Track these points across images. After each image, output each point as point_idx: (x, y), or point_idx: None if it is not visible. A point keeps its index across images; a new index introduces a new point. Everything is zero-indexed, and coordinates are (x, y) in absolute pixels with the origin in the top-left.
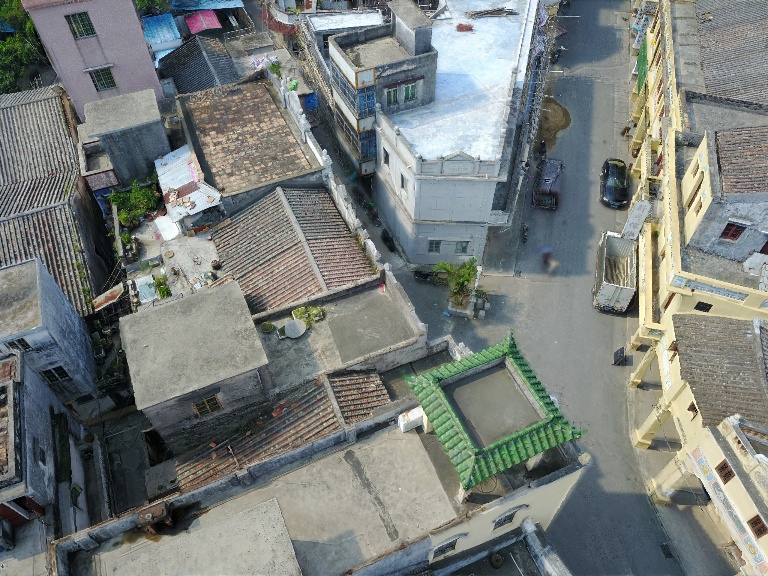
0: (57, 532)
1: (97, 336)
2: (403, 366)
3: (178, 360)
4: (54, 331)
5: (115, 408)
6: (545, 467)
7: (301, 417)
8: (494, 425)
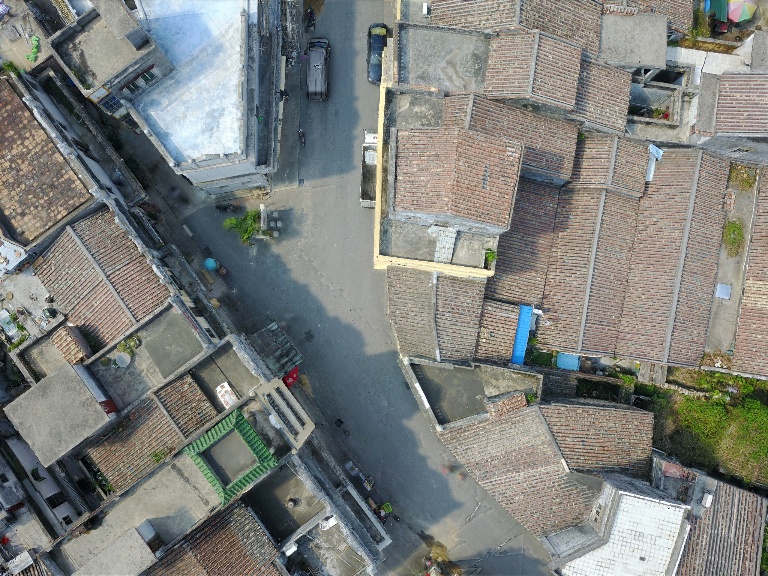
0: (36, 510)
1: None
2: (205, 359)
3: (54, 431)
4: None
5: None
6: (280, 449)
7: (148, 419)
8: (234, 466)
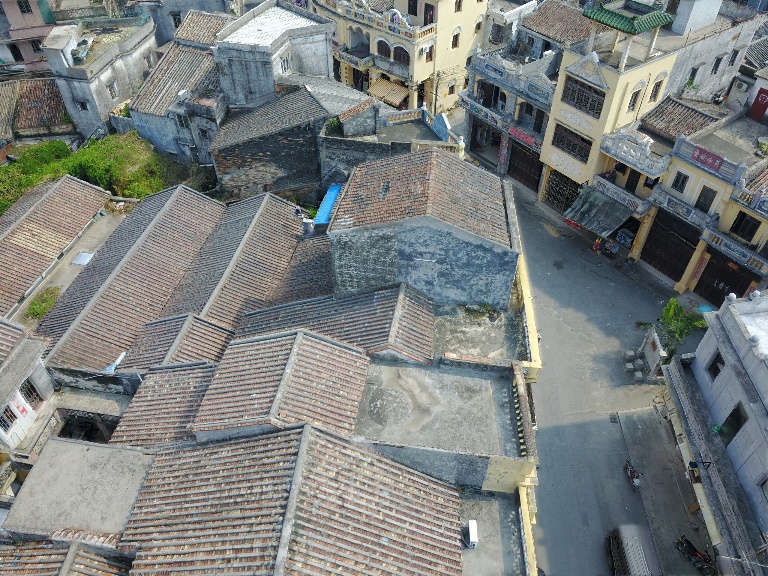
0: None
1: None
2: None
3: None
4: None
5: None
6: None
7: None
8: None
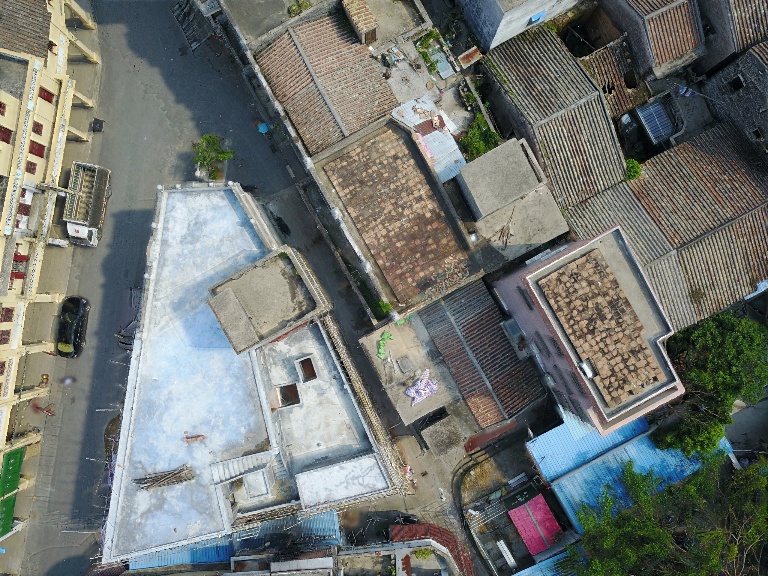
0: None
1: None
2: None
3: None
4: None
5: None
6: None
7: None
8: None
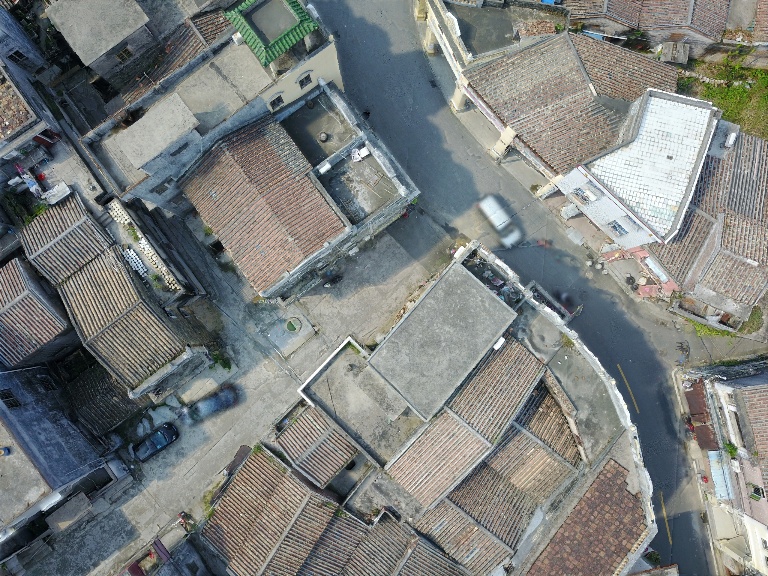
0: (73, 145)
1: (25, 23)
2: (239, 0)
3: (95, 30)
4: (2, 27)
5: (63, 72)
6: (317, 48)
7: (183, 50)
8: (275, 31)
